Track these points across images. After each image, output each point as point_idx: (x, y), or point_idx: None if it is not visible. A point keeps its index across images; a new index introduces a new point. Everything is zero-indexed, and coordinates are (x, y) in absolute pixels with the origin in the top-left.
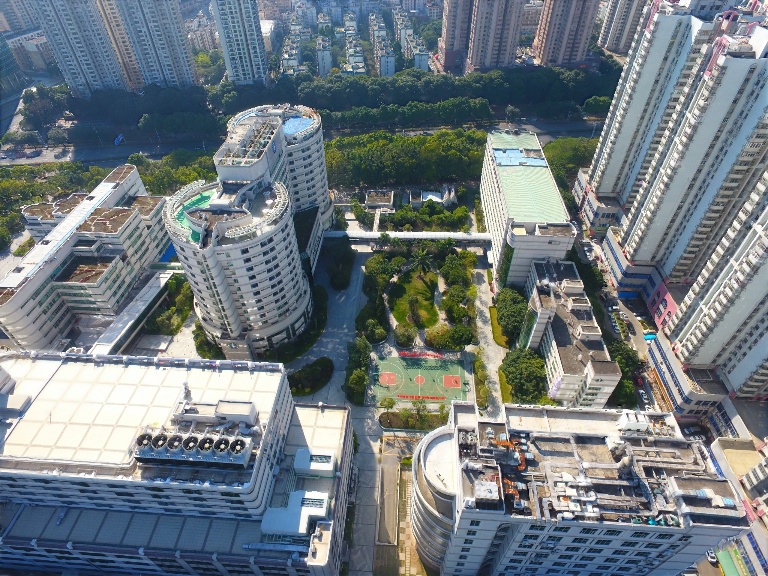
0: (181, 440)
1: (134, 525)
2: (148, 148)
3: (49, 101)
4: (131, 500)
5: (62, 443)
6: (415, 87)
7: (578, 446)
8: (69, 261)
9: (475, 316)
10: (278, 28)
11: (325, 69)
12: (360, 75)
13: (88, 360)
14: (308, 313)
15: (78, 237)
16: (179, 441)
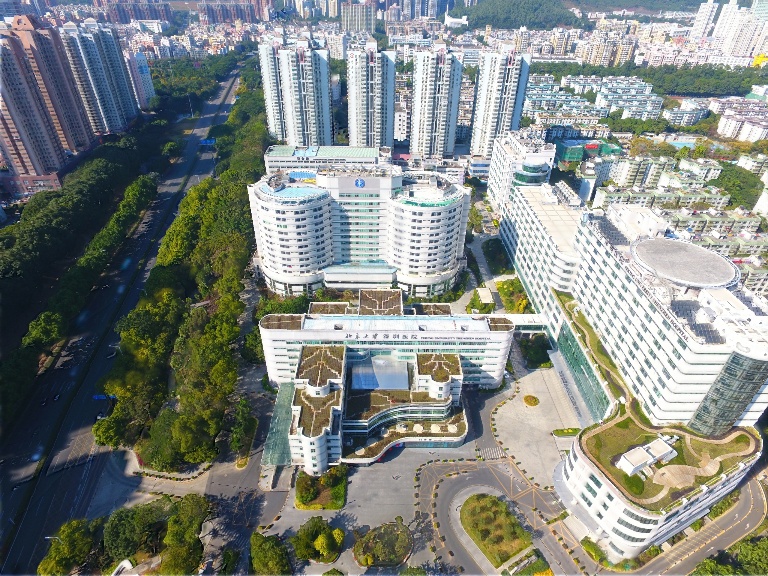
0: None
1: None
2: None
3: None
4: None
5: None
6: (82, 200)
7: None
8: None
9: None
10: None
11: None
12: (7, 227)
13: None
14: None
15: None
16: None
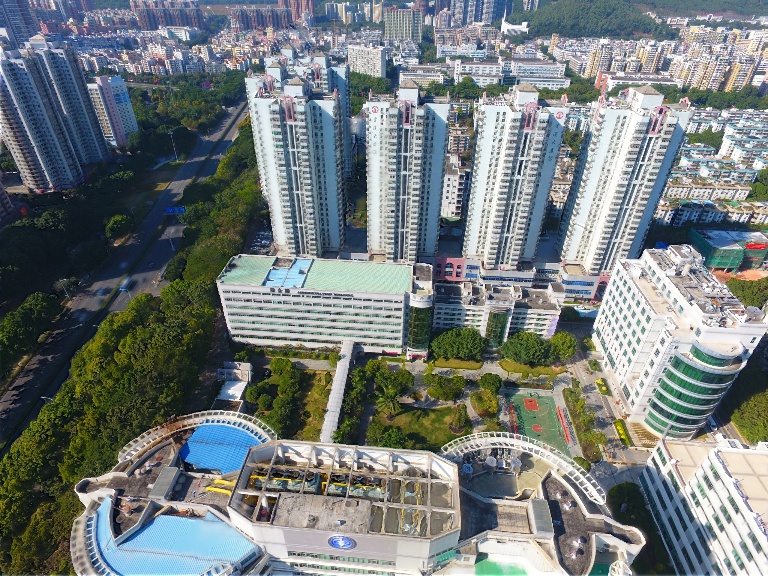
0: None
1: None
2: None
3: None
4: None
5: None
6: None
7: (677, 286)
8: None
9: None
10: None
11: None
12: None
13: None
14: None
15: None
16: None
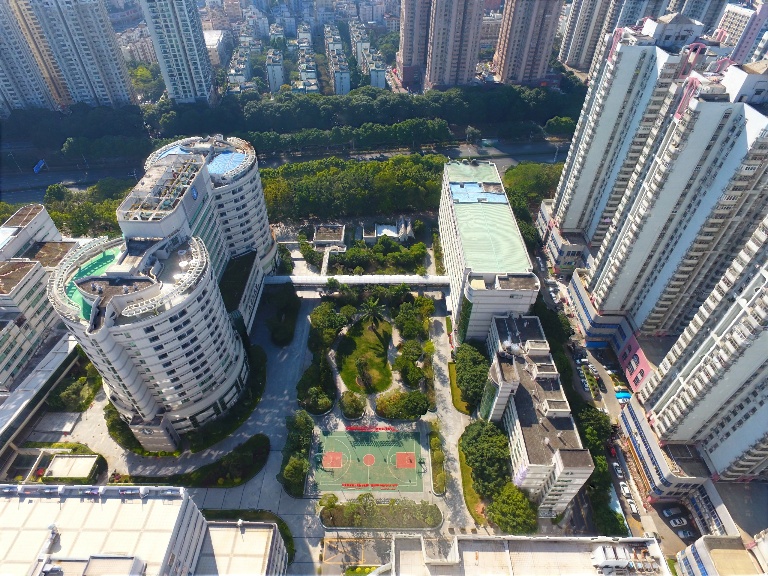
0: None
1: None
2: (74, 175)
3: None
4: None
5: None
6: (370, 107)
7: None
8: None
9: (432, 375)
10: (228, 39)
11: (276, 85)
12: (312, 93)
13: None
14: (241, 381)
15: None
16: None
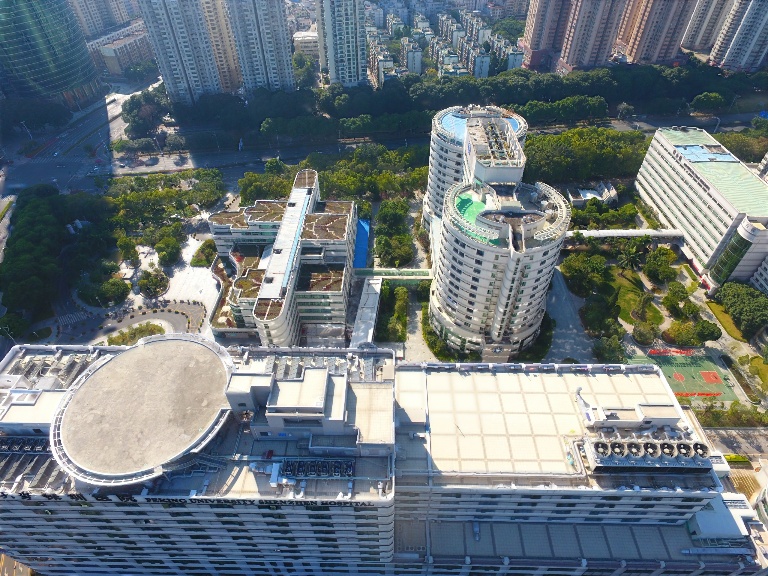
0: (636, 446)
1: (555, 536)
2: (268, 153)
3: (156, 107)
4: (560, 511)
5: (492, 455)
6: (527, 86)
7: None
8: (299, 270)
9: None
10: None
11: (414, 70)
12: (466, 75)
13: (450, 369)
14: None
15: (302, 245)
16: (635, 448)
